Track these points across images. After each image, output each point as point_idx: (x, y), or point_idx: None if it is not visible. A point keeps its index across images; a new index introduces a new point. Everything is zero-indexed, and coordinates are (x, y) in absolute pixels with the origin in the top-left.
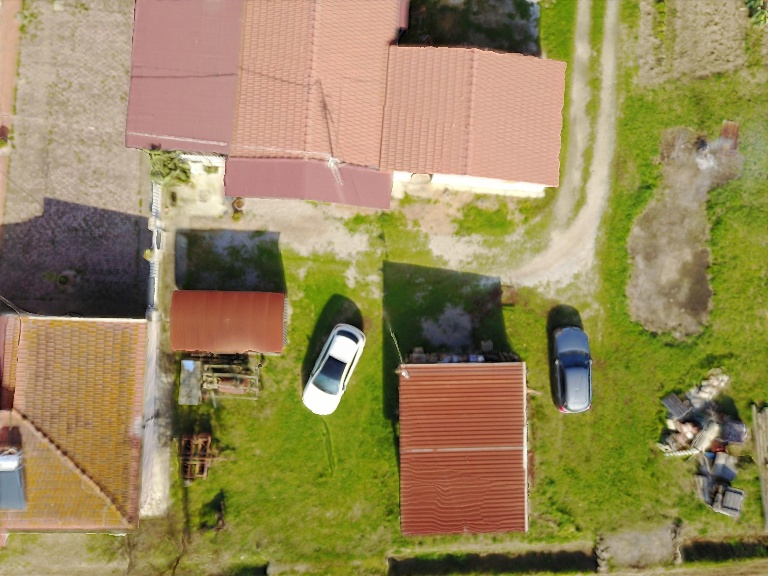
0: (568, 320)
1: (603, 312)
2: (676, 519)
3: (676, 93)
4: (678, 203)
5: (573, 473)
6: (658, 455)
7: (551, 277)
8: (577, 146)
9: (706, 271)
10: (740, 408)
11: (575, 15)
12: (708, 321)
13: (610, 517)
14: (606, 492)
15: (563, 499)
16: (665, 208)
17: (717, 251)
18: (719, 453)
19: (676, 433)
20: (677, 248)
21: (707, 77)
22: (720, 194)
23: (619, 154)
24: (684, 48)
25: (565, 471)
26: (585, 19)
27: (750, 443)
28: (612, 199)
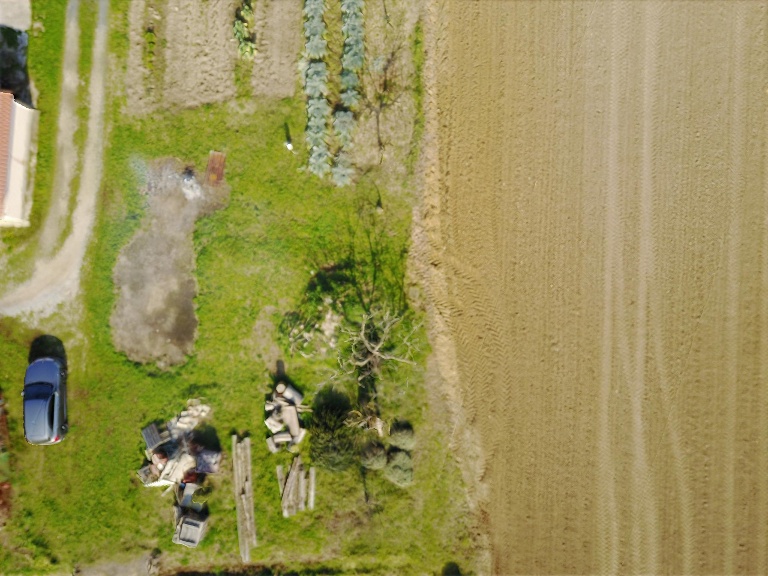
0: (52, 351)
1: (87, 343)
2: (155, 550)
3: (164, 123)
4: (166, 233)
5: (52, 505)
6: (139, 486)
7: (34, 308)
8: (64, 176)
9: (192, 301)
10: (222, 438)
11: (63, 44)
12: (193, 351)
13: (89, 549)
14: (86, 524)
15: (41, 532)
16: (152, 238)
17: (202, 281)
18: (188, 484)
19: (151, 464)
20: (164, 278)
21: (197, 107)
22: (206, 224)
23: (105, 184)
24: (174, 78)
25: (44, 503)
26: (73, 48)
27: (230, 473)
28: (98, 229)
